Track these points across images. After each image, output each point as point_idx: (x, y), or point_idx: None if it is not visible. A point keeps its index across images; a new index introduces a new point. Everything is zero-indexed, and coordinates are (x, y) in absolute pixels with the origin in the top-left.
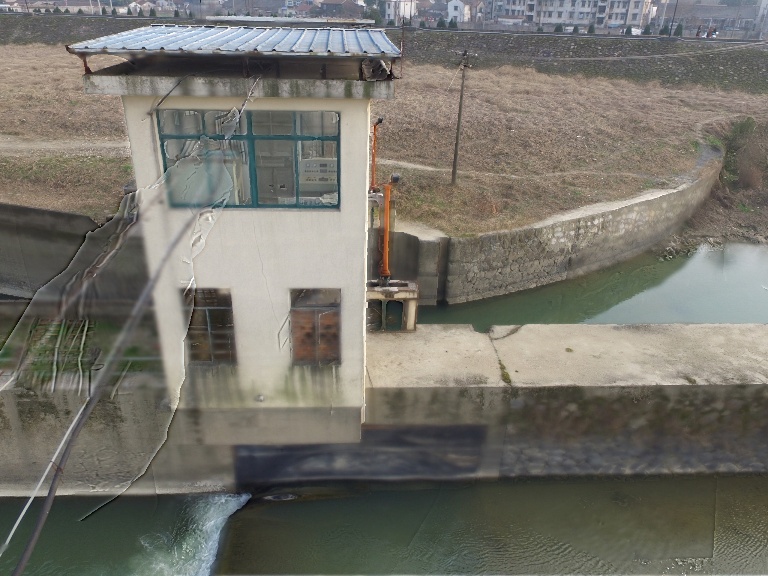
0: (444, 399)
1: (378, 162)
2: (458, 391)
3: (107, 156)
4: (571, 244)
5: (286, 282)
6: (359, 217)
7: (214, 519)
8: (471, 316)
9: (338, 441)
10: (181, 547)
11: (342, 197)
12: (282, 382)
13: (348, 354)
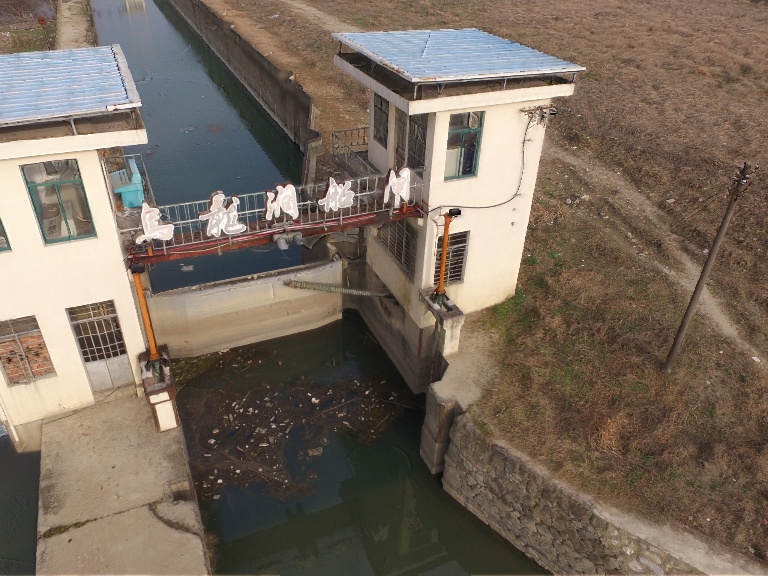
0: None
1: (681, 278)
2: None
3: None
4: None
5: None
6: None
7: None
8: (470, 529)
9: None
10: None
11: None
12: None
13: None
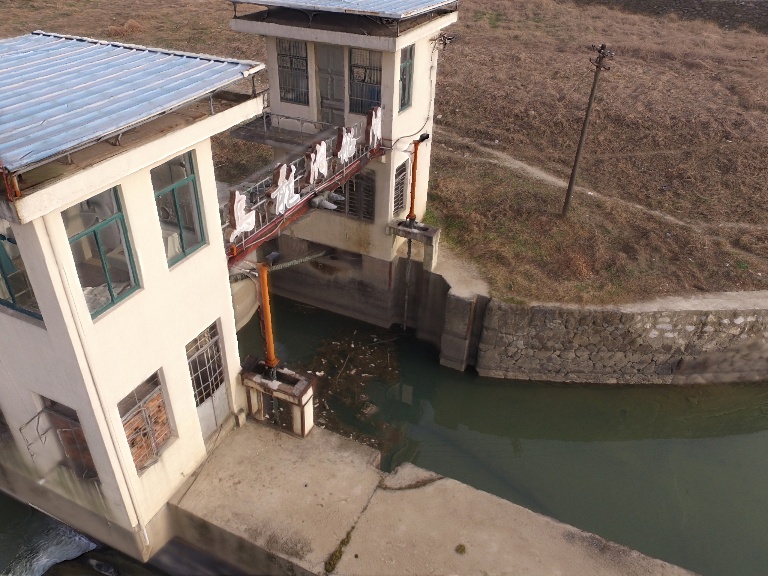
0: (252, 553)
1: (504, 162)
2: (265, 553)
3: None
4: (686, 342)
5: (25, 383)
6: (67, 343)
7: (51, 557)
8: (510, 395)
9: (124, 551)
10: (7, 574)
11: (43, 315)
12: (56, 474)
13: (104, 477)
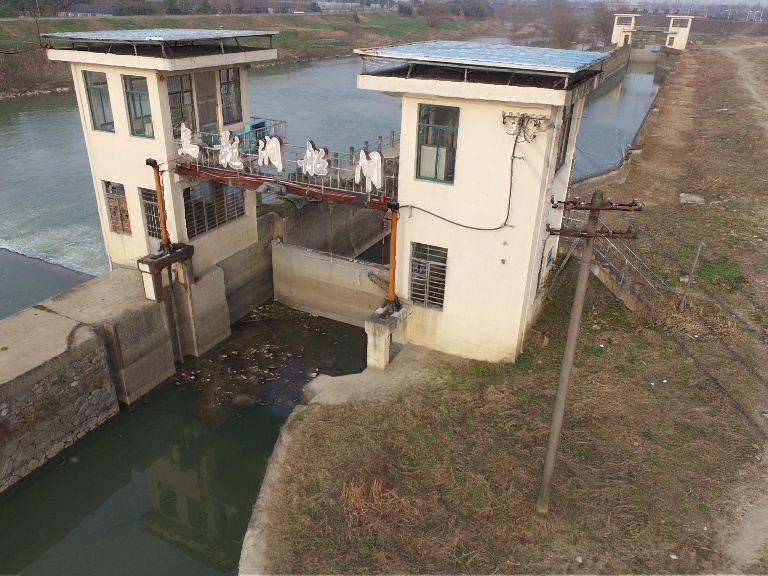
0: None
1: None
2: None
3: (763, 243)
4: None
5: None
6: None
7: None
8: None
9: None
10: None
11: None
12: None
13: None
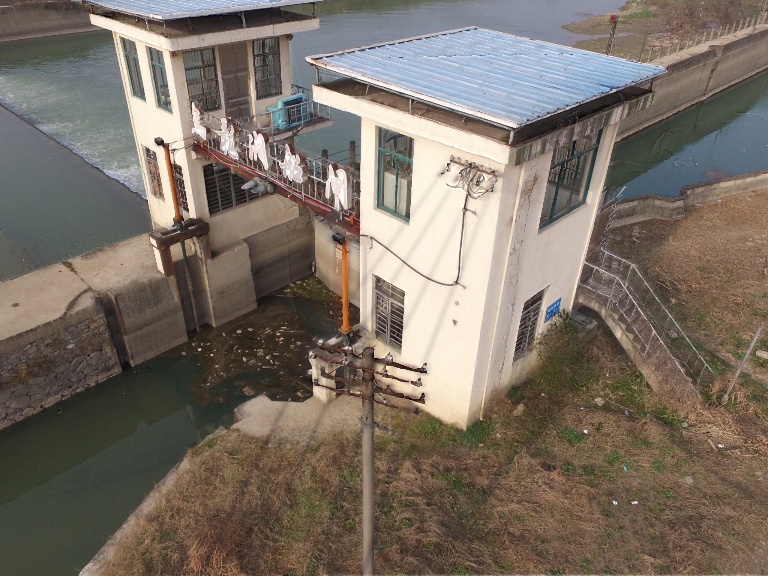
0: None
1: None
2: None
3: None
4: None
5: None
6: None
7: None
8: None
9: None
10: None
11: None
12: None
13: None
